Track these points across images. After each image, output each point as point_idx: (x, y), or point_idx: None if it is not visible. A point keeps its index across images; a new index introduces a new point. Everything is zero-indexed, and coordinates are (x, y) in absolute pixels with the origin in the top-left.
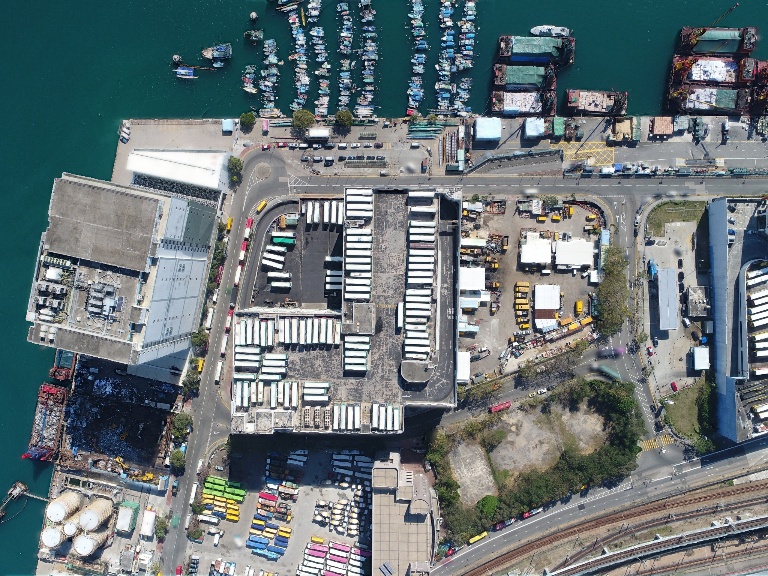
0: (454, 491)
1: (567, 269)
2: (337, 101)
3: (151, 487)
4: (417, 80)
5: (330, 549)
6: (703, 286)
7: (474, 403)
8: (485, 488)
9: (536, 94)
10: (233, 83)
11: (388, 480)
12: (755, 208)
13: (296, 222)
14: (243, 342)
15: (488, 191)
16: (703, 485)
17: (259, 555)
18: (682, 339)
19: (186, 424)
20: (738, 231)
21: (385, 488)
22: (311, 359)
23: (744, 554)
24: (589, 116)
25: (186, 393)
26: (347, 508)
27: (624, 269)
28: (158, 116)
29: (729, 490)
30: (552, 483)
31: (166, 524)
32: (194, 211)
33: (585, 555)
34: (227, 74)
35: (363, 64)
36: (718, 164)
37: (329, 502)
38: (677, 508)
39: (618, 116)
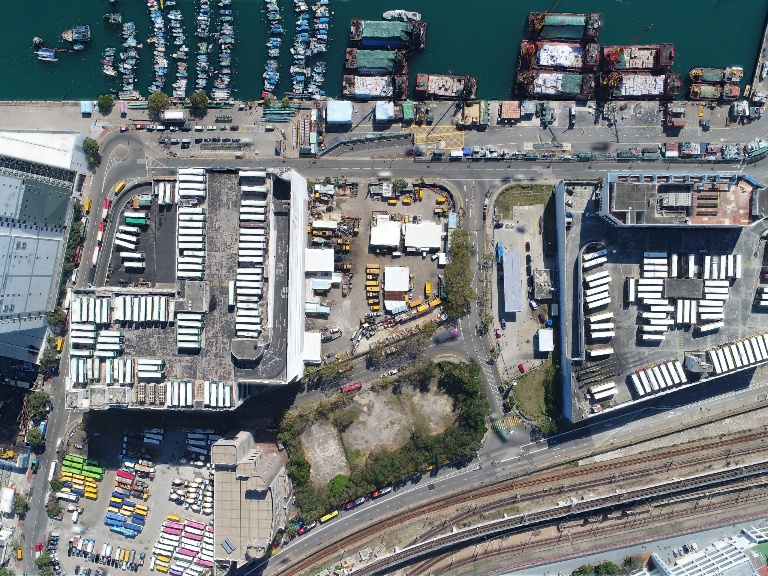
0: (305, 470)
1: (417, 251)
2: (195, 84)
3: (12, 465)
4: (273, 64)
5: (185, 527)
6: (548, 269)
7: (327, 383)
8: (337, 468)
9: (387, 78)
10: (93, 65)
11: (227, 457)
12: (593, 191)
13: (149, 203)
14: (78, 319)
15: (341, 174)
16: (549, 466)
17: (117, 532)
18: (529, 321)
19: (43, 402)
20: (576, 214)
21: (227, 465)
22: (147, 336)
23: (589, 534)
24: (440, 100)
25: (46, 372)
26: (202, 486)
27: (470, 251)
28: (20, 98)
29: (574, 471)
30: (398, 462)
31: (24, 501)
32: (33, 190)
33: (435, 534)
34: (87, 57)
35: (220, 47)
36: (565, 148)
37: (185, 480)
38: (524, 488)
39: (468, 100)
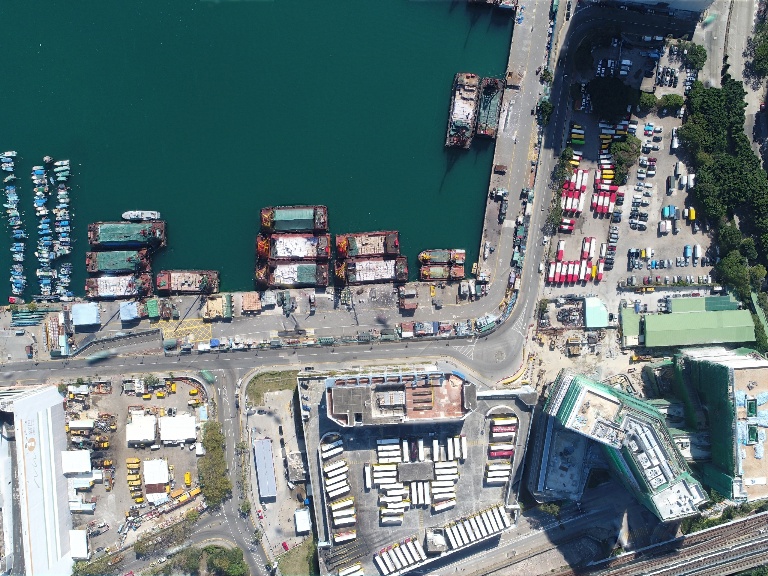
0: None
1: (175, 443)
2: None
3: None
4: (18, 268)
5: None
6: (300, 452)
7: (100, 575)
8: None
9: (131, 277)
10: None
11: None
12: None
13: None
14: None
15: (94, 372)
16: None
17: None
18: (289, 501)
19: None
20: (313, 406)
21: None
22: None
23: None
24: (185, 295)
25: None
26: None
27: (223, 442)
28: None
29: None
30: None
31: None
32: None
33: None
34: None
35: None
36: (308, 334)
37: None
38: None
39: (211, 294)
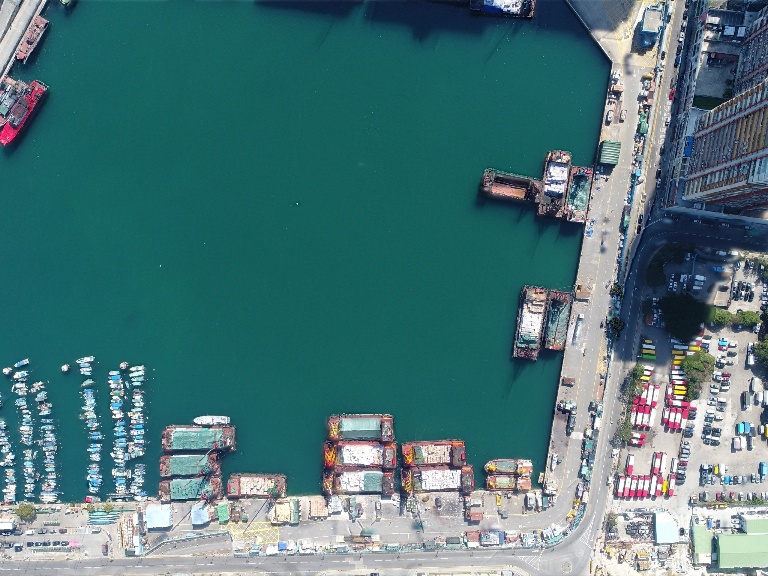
0: None
1: None
2: (24, 488)
3: None
4: (95, 467)
5: None
6: None
7: None
8: None
9: (202, 481)
10: None
11: None
12: None
13: None
14: None
15: (166, 571)
16: None
17: None
18: None
19: None
20: None
21: None
22: None
23: None
24: (254, 497)
25: None
26: None
27: None
28: None
29: None
30: None
31: None
32: None
33: None
34: None
35: (44, 453)
36: (374, 540)
37: None
38: None
39: (279, 498)
